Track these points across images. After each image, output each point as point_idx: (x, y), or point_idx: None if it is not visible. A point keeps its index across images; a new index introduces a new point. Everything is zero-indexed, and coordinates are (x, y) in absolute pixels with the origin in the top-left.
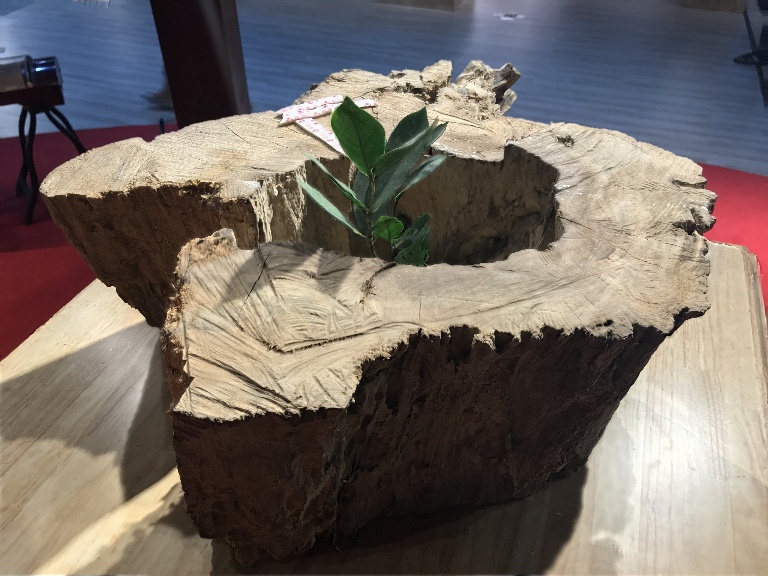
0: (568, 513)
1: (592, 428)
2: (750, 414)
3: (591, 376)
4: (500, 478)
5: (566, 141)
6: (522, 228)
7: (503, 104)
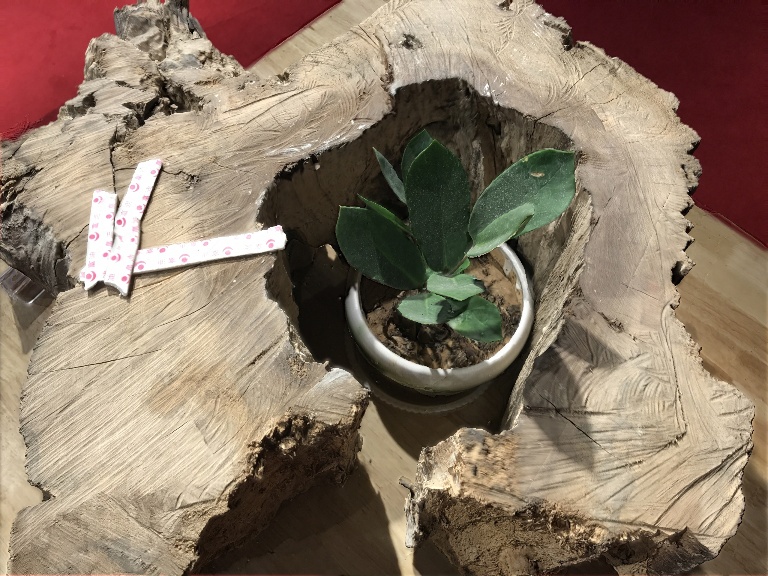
0: None
1: None
2: None
3: None
4: None
5: (407, 41)
6: None
7: (199, 35)
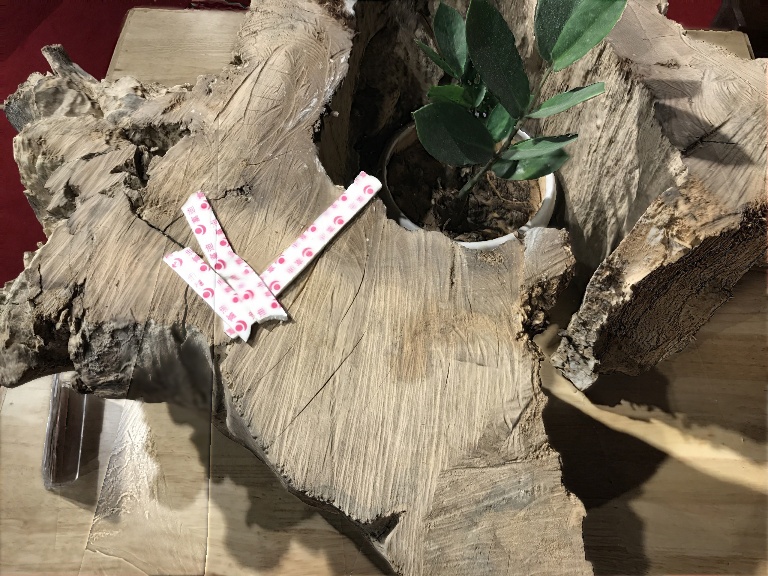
0: None
1: None
2: None
3: None
4: None
5: None
6: (379, 60)
7: None
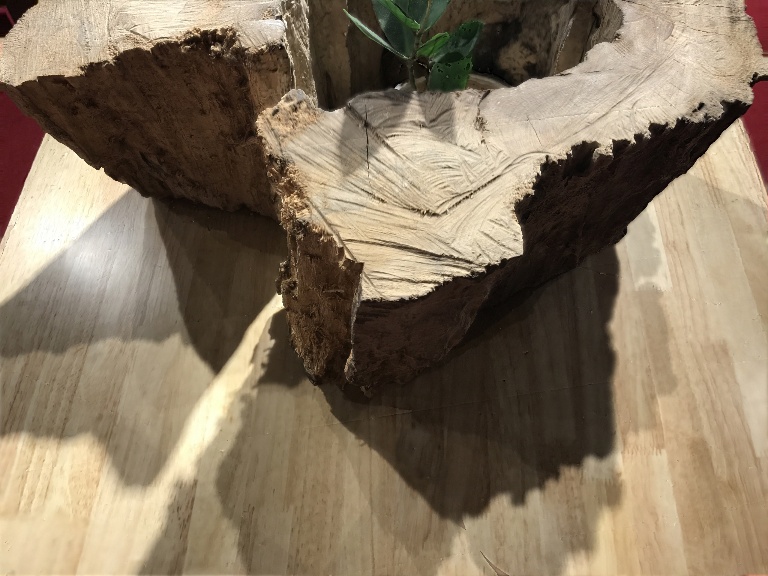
0: (609, 271)
1: None
2: (729, 143)
3: (680, 158)
4: (561, 259)
5: None
6: (539, 9)
7: None
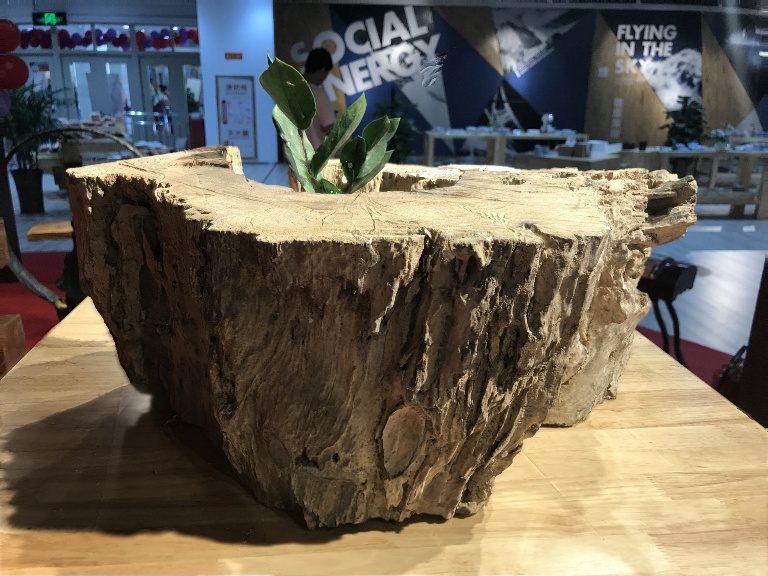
0: (255, 537)
1: (273, 419)
2: None
3: None
4: None
5: (519, 184)
6: None
7: (662, 218)
